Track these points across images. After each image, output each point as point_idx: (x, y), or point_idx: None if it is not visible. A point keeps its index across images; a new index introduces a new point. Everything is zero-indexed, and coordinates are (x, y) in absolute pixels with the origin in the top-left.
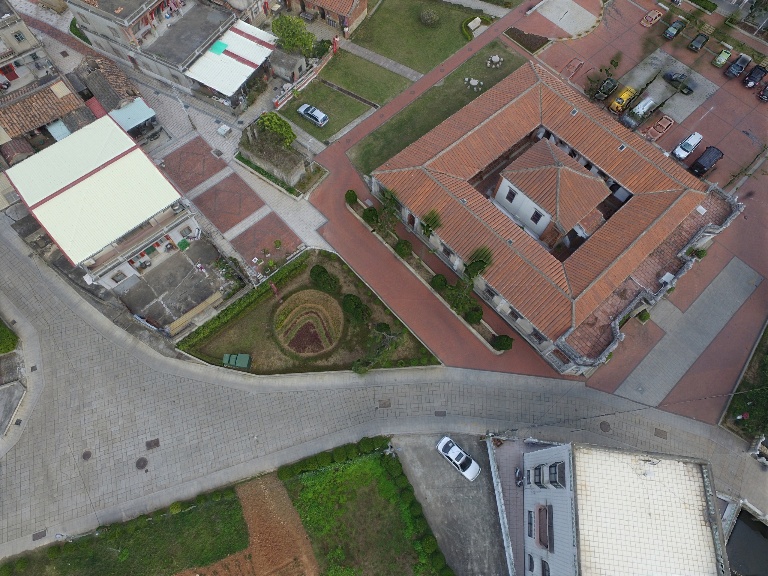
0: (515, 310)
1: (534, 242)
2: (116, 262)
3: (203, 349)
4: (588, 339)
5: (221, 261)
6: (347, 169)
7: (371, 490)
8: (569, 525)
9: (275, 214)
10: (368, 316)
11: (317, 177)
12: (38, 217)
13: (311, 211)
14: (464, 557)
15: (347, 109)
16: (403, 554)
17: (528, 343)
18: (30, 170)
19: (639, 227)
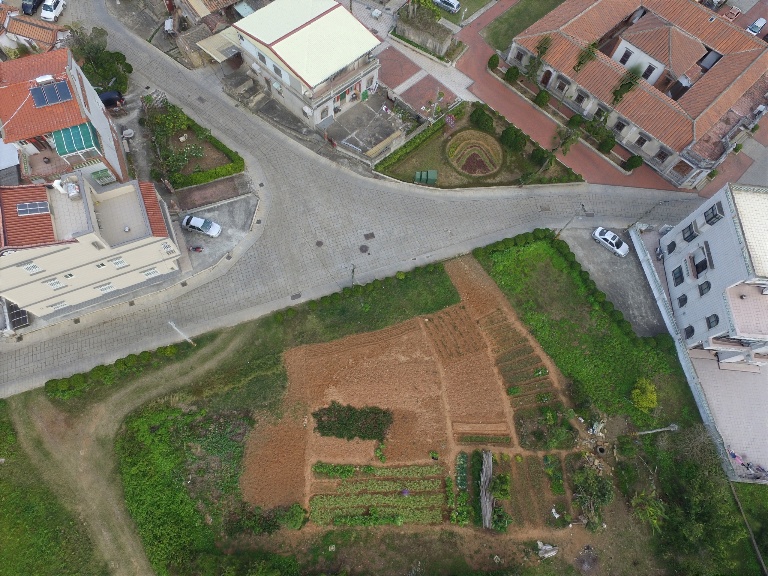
0: (645, 134)
1: (652, 87)
2: (328, 97)
3: (394, 172)
4: (706, 150)
5: (397, 108)
6: (482, 45)
7: (547, 264)
8: (733, 234)
9: (431, 76)
10: (524, 145)
11: (460, 50)
12: (277, 52)
13: (460, 75)
14: (626, 306)
15: (473, 1)
16: (579, 305)
17: (650, 167)
18: (255, 22)
19: (734, 74)
